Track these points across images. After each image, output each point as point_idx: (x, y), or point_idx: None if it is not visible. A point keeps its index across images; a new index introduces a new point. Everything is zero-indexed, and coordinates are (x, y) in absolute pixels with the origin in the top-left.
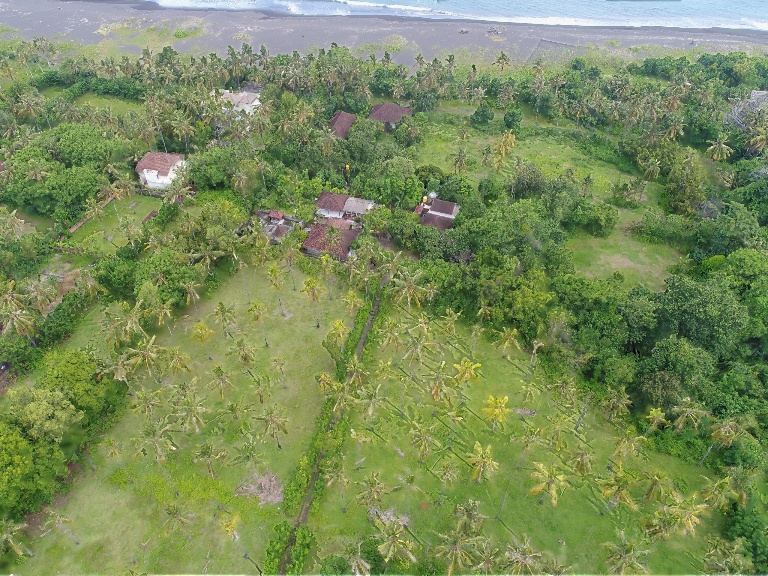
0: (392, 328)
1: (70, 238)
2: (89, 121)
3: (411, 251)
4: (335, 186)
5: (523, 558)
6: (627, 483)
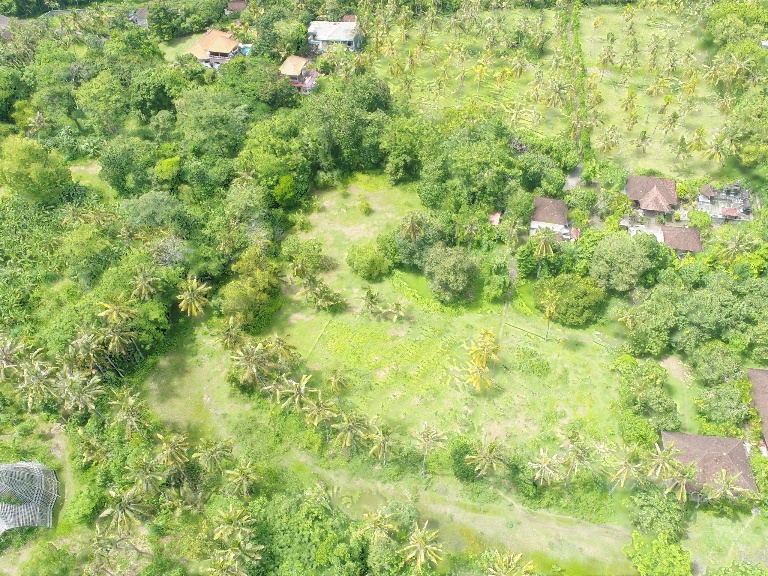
0: None
1: None
2: None
3: None
4: None
5: None
6: None
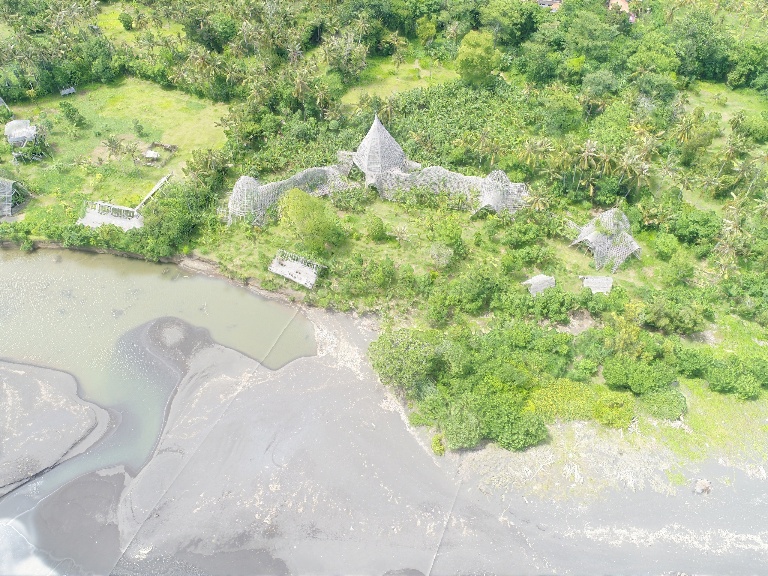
0: None
1: None
2: None
3: None
4: None
5: None
6: None
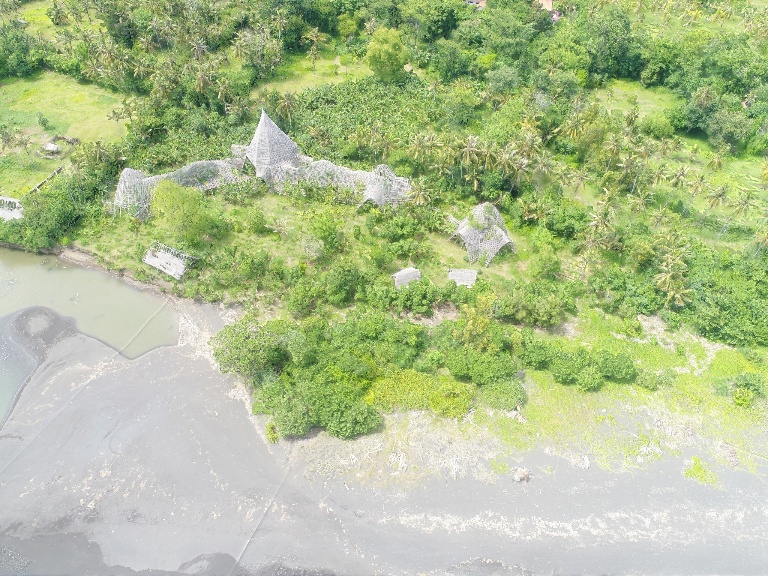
0: None
1: None
2: None
3: None
4: None
5: None
6: None
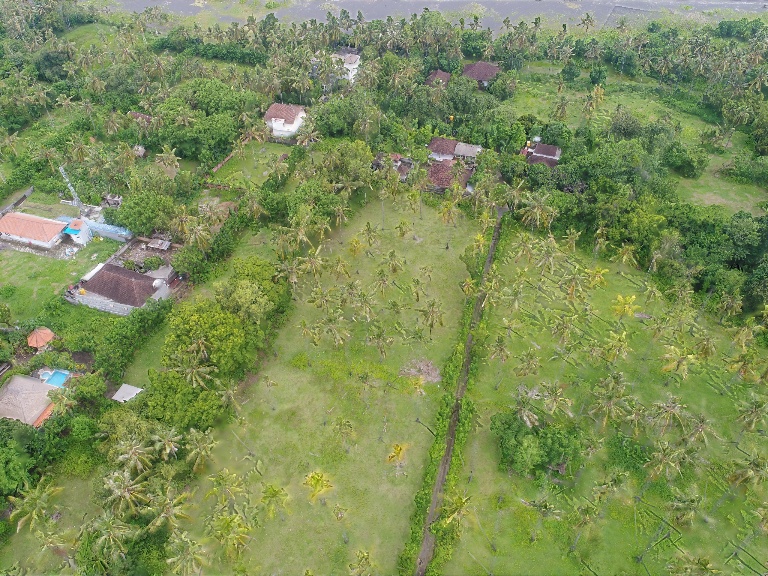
0: (526, 241)
1: (213, 177)
2: (216, 77)
3: (521, 187)
4: (442, 134)
5: (672, 407)
6: (752, 358)
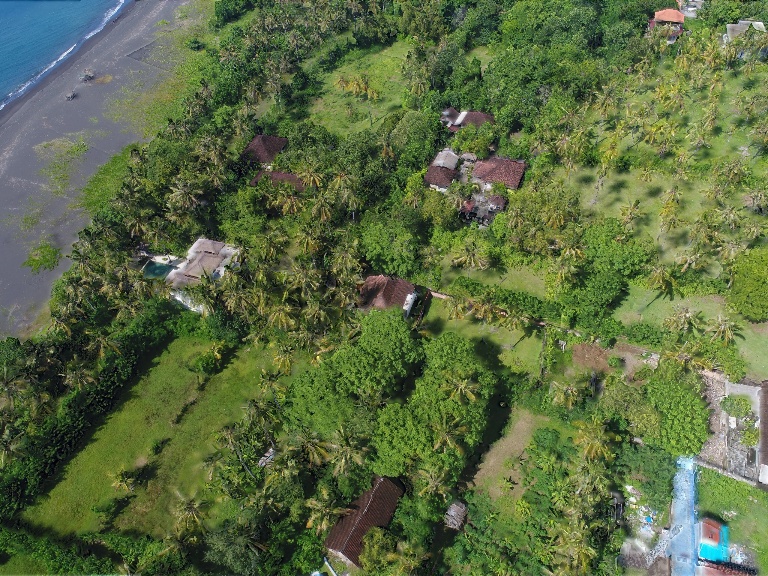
0: None
1: None
2: None
3: None
4: None
5: None
6: None
